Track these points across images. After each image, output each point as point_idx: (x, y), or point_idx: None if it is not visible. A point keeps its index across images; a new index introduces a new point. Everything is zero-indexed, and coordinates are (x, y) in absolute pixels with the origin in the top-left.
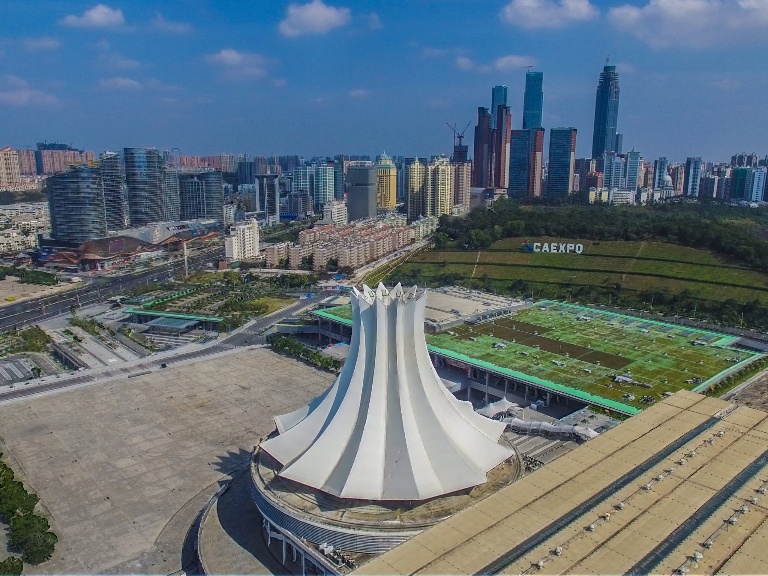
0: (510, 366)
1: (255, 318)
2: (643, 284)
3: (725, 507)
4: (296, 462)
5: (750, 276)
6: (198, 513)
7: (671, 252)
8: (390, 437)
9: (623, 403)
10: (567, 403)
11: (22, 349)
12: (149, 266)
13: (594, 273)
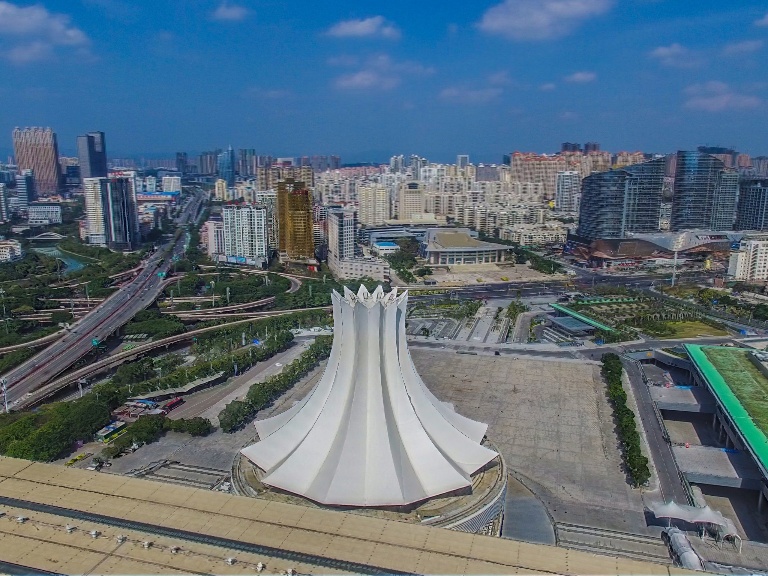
0: None
1: (649, 338)
2: None
3: None
4: None
5: None
6: None
7: None
8: None
9: None
10: None
11: (453, 315)
12: (652, 272)
13: None
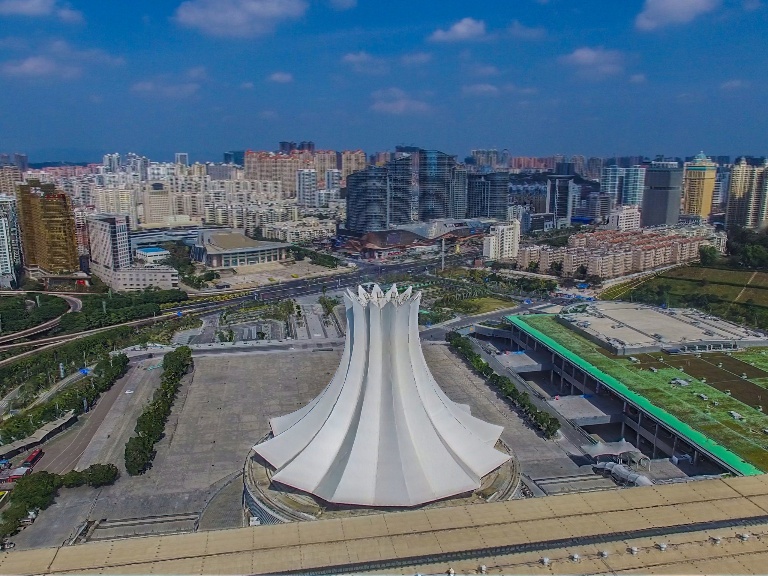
0: (667, 407)
1: (462, 316)
2: None
3: None
4: (270, 440)
5: None
6: None
7: None
8: (348, 437)
9: None
10: None
11: (271, 316)
12: (418, 259)
13: None
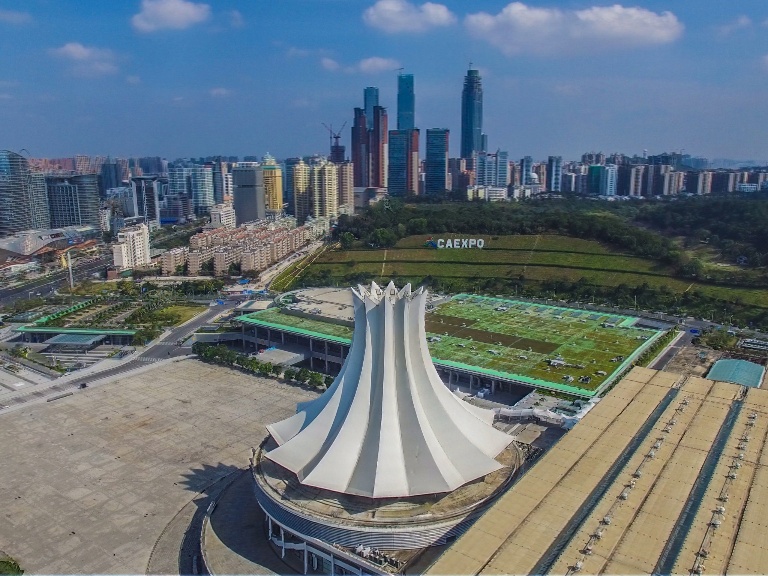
0: (452, 358)
1: (169, 328)
2: (543, 274)
3: (721, 465)
4: (315, 468)
5: (635, 263)
6: (183, 536)
7: (564, 244)
8: (405, 434)
9: (565, 384)
10: (510, 389)
11: None
12: (24, 279)
13: (497, 266)
